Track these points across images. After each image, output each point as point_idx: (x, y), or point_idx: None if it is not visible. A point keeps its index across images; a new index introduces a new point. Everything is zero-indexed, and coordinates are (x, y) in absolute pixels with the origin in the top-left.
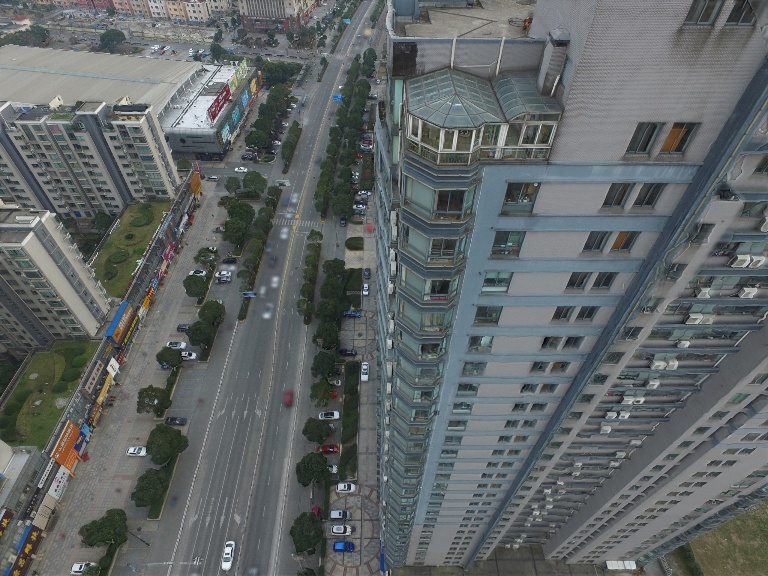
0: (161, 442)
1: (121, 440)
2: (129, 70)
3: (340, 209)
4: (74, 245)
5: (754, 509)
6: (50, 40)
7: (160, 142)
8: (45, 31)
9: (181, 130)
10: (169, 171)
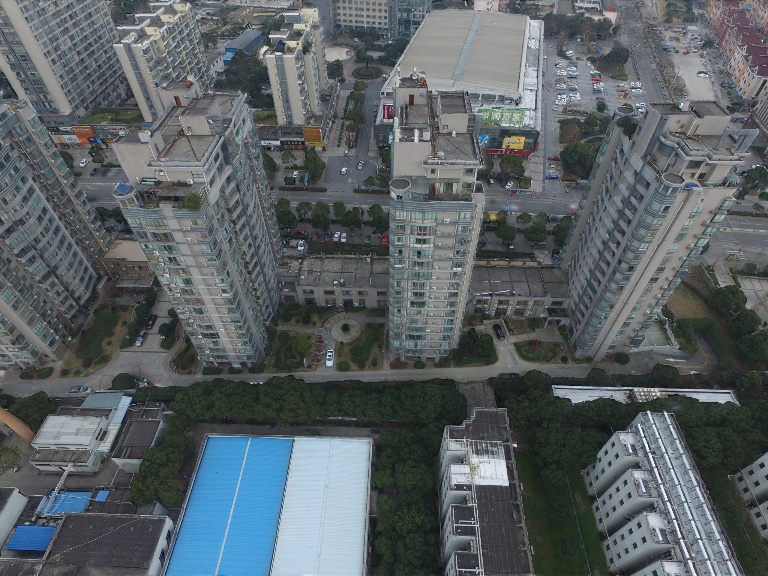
0: None
1: None
2: (482, 64)
3: None
4: (152, 72)
5: None
6: (611, 37)
7: (285, 82)
8: (612, 28)
9: (380, 109)
10: (286, 106)
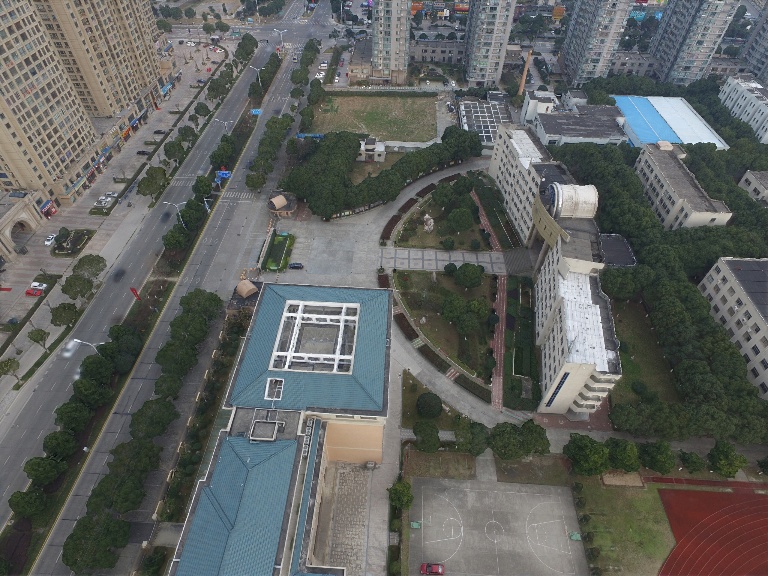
0: (416, 13)
1: (422, 23)
2: None
3: (556, 42)
4: None
5: (393, 114)
6: None
7: None
8: None
9: None
10: None
